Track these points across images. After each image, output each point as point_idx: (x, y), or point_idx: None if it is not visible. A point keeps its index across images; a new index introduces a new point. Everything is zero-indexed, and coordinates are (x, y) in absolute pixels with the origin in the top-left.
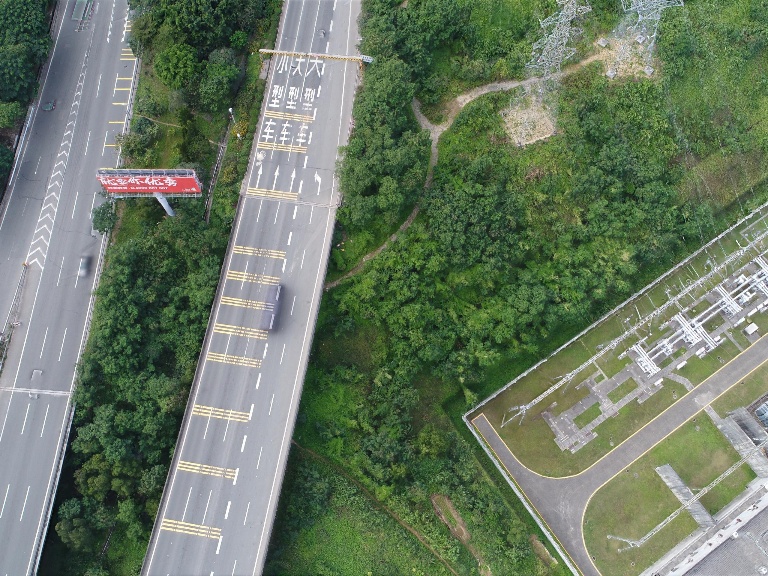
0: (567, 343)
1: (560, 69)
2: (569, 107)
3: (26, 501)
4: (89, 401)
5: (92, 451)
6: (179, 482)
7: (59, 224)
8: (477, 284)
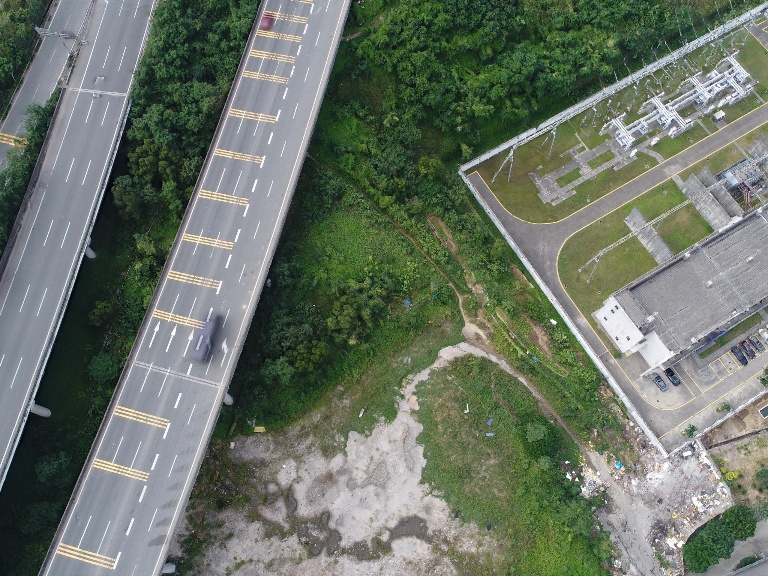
0: (554, 116)
1: None
2: None
3: (88, 171)
4: (143, 98)
5: (143, 140)
6: (215, 164)
7: None
8: (478, 53)
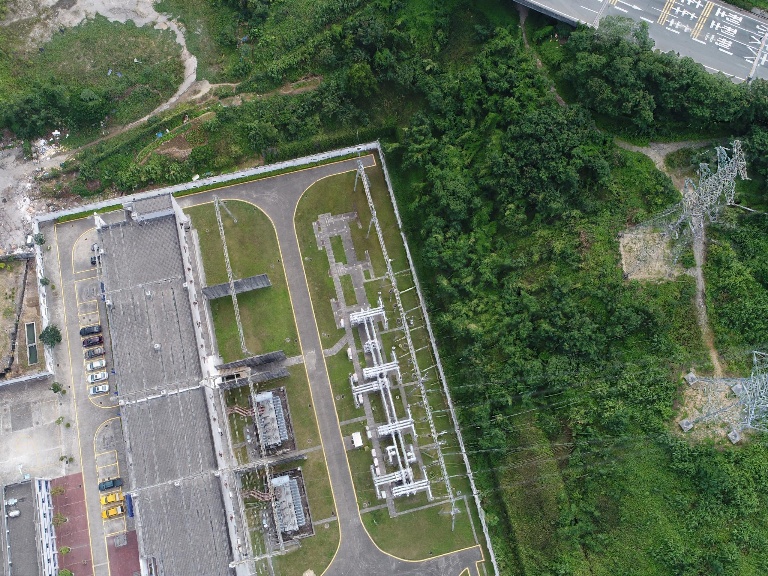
0: None
1: (710, 321)
2: (655, 304)
3: None
4: None
5: None
6: None
7: None
8: None
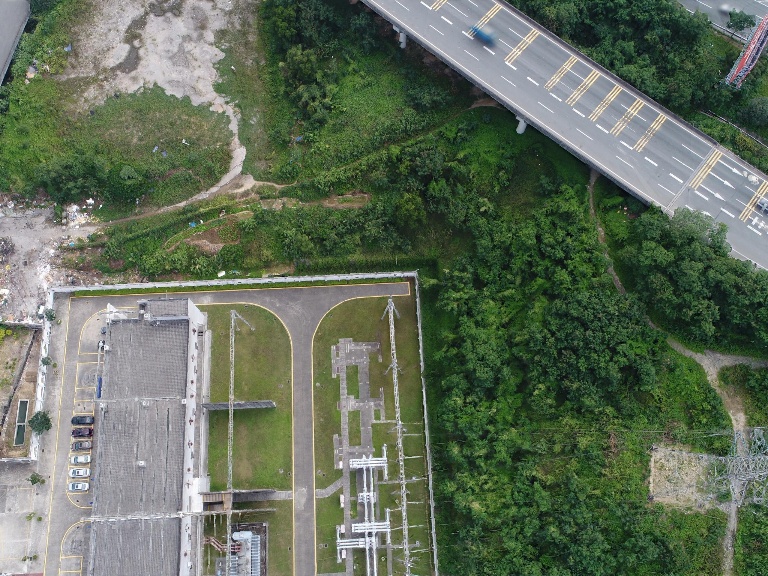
0: None
1: (735, 567)
2: (678, 536)
3: None
4: None
5: None
6: (487, 1)
7: (755, 5)
8: None
